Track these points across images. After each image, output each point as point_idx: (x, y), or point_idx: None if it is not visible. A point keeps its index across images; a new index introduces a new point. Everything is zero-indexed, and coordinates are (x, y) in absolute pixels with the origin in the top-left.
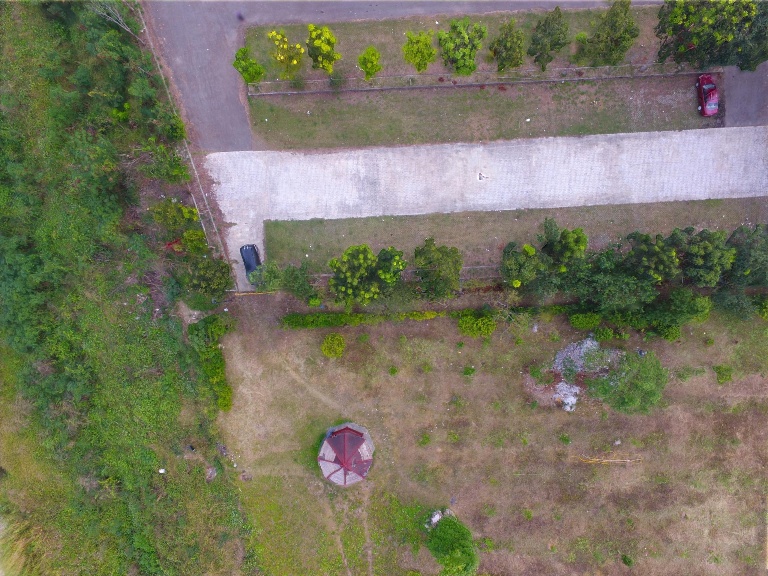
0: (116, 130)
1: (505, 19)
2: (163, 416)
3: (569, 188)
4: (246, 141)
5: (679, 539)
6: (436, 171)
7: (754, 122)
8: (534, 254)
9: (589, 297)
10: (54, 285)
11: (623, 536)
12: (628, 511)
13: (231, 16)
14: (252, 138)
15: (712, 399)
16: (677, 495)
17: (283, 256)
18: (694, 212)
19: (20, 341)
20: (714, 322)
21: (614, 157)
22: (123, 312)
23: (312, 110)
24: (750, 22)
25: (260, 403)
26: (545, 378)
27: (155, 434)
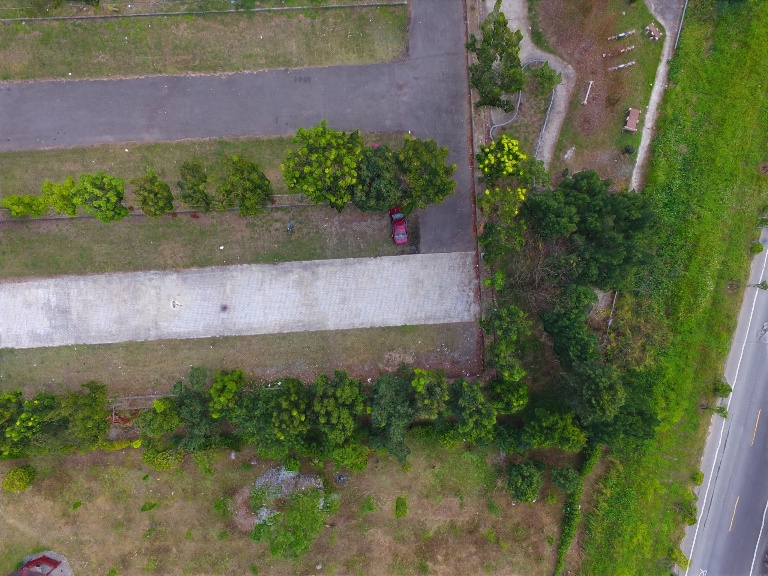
0: None
1: (196, 147)
2: None
3: (264, 315)
4: None
5: None
6: (129, 299)
7: (449, 248)
8: (162, 411)
9: None
10: None
11: None
12: None
13: None
14: None
15: (412, 522)
16: None
17: None
18: (390, 338)
19: None
20: (412, 447)
21: (309, 284)
22: None
23: None
24: (366, 183)
25: None
26: (246, 503)
27: None
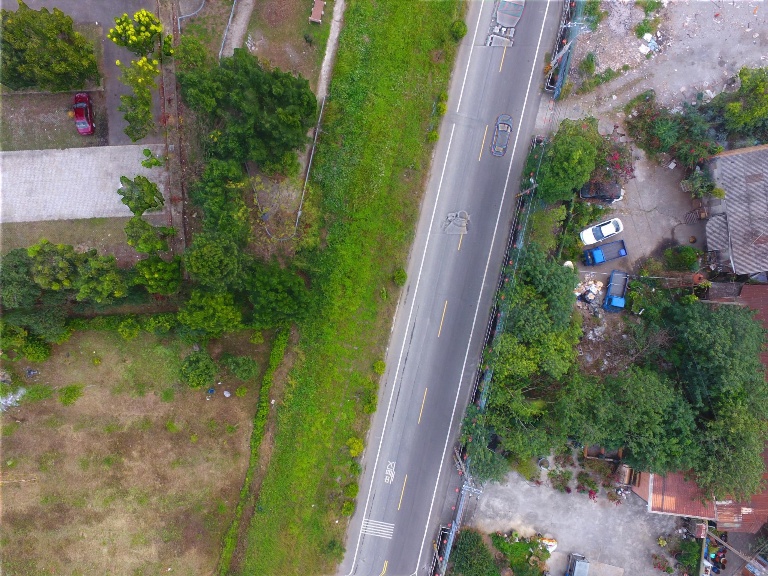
0: None
1: None
2: None
3: None
4: None
5: (78, 559)
6: None
7: (138, 141)
8: None
9: None
10: None
11: (21, 557)
12: (27, 531)
13: None
14: None
15: (106, 418)
16: (74, 514)
17: None
18: (79, 231)
19: None
20: (103, 341)
21: None
22: None
23: None
24: None
25: None
26: None
27: None
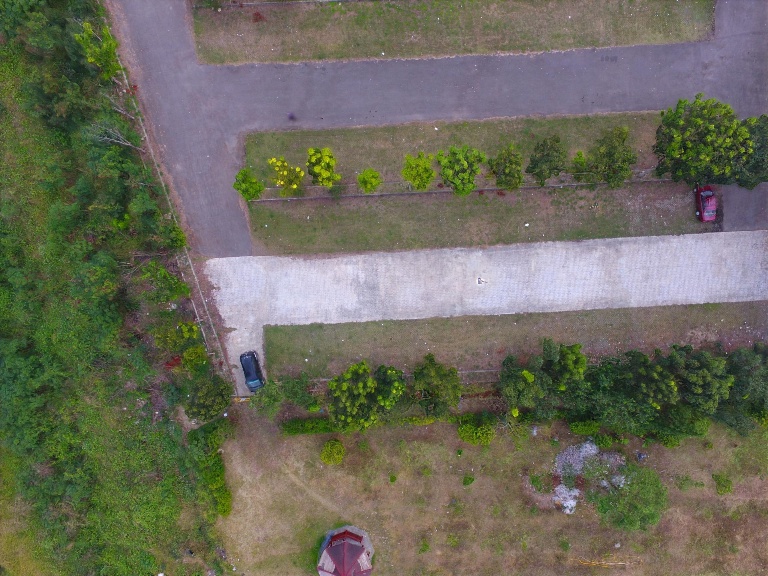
0: (116, 237)
1: (504, 125)
2: (162, 521)
3: (568, 292)
4: (246, 246)
5: None
6: (435, 276)
7: (752, 227)
8: (533, 381)
9: (588, 408)
10: (54, 388)
11: None
12: None
13: (231, 123)
14: (252, 243)
15: (711, 502)
16: None
17: (283, 361)
18: (693, 316)
19: (19, 443)
20: (713, 425)
21: (613, 261)
22: (123, 417)
23: (312, 215)
24: (747, 154)
25: (259, 506)
26: (544, 481)
27: (154, 538)
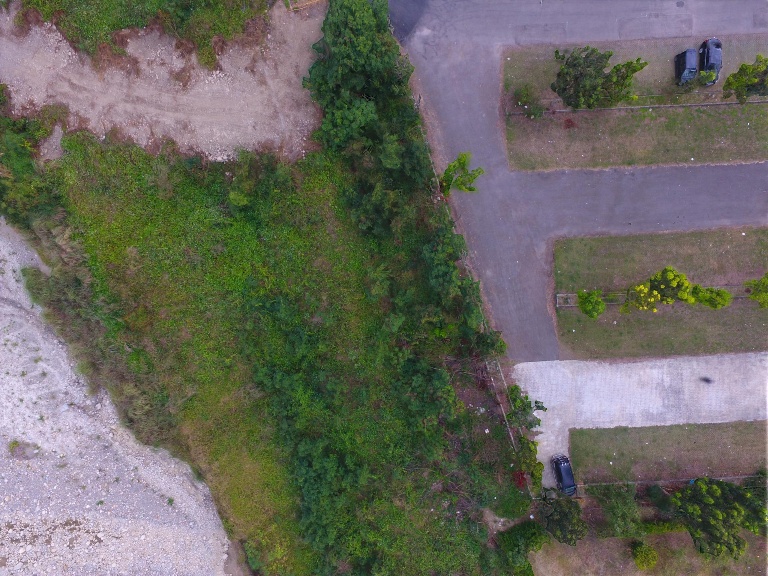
0: (428, 342)
1: None
2: None
3: None
4: (553, 351)
5: None
6: (740, 380)
7: None
8: None
9: None
10: None
11: None
12: None
13: (540, 229)
14: (559, 348)
15: None
16: None
17: (588, 464)
18: None
19: (320, 540)
20: None
21: None
22: (431, 519)
23: (618, 320)
24: None
25: None
26: None
27: None
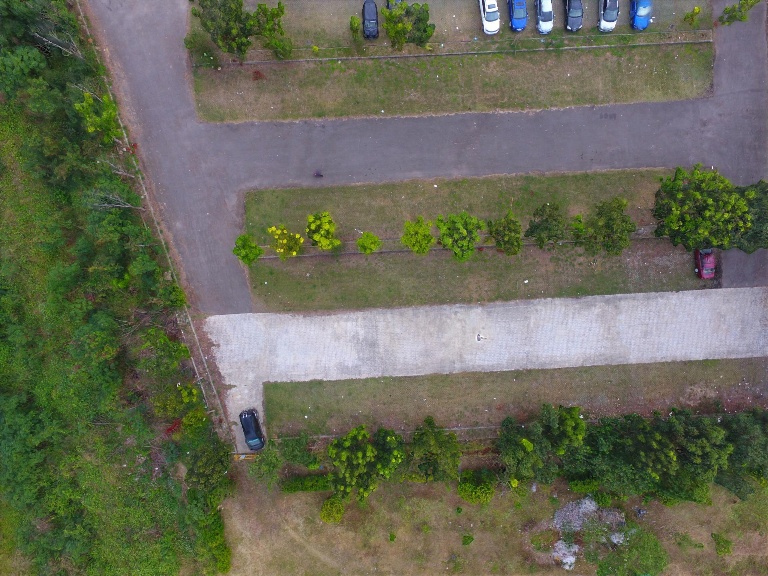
0: (116, 294)
1: (503, 182)
2: None
3: (567, 349)
4: (246, 304)
5: None
6: (435, 332)
7: (751, 283)
8: (532, 450)
9: None
10: (53, 443)
11: None
12: None
13: (231, 180)
14: (252, 300)
15: (711, 558)
16: None
17: (282, 417)
18: (692, 372)
19: (19, 499)
20: None
21: (612, 318)
22: (122, 474)
23: (311, 272)
24: None
25: (259, 562)
26: (544, 536)
27: None
